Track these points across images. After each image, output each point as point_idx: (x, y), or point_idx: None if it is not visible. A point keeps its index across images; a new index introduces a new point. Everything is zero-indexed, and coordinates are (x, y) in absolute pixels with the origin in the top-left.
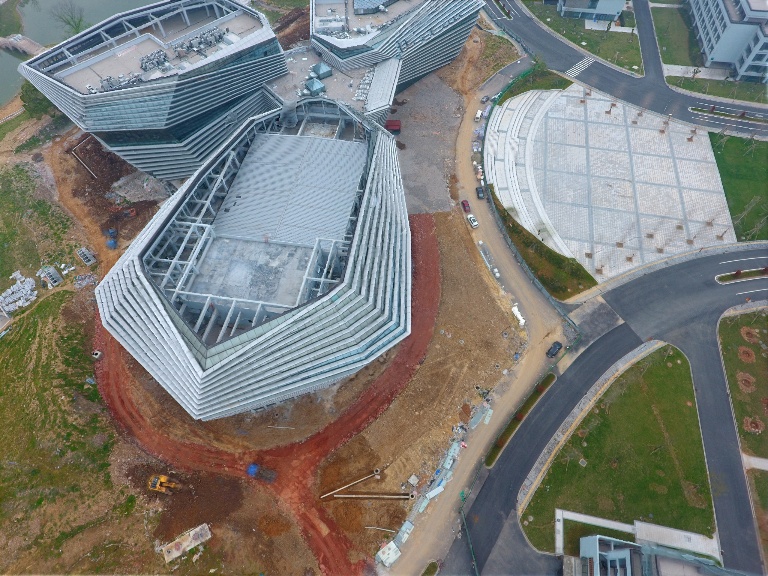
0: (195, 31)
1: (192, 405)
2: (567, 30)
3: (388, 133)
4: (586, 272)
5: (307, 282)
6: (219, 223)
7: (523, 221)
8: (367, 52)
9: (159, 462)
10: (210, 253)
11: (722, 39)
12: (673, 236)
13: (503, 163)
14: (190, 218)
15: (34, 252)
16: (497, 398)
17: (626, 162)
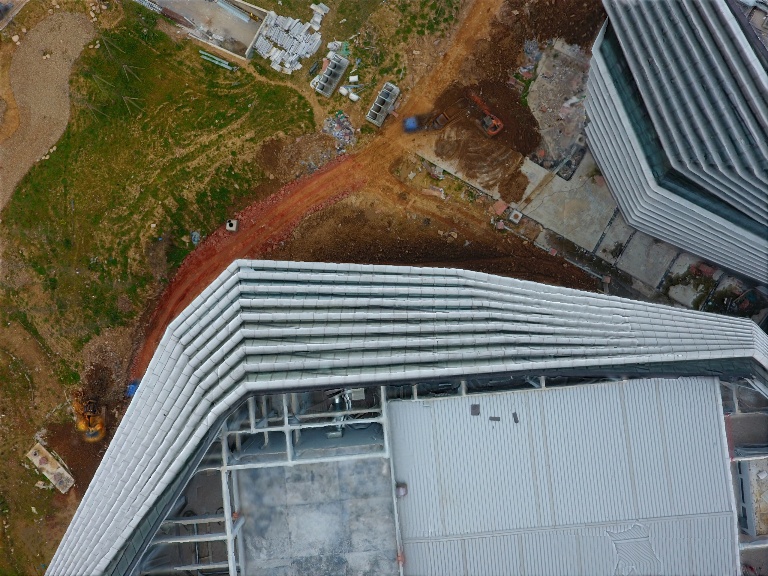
0: None
1: None
2: None
3: None
4: None
5: None
6: (439, 410)
7: None
8: None
9: (122, 391)
10: (349, 451)
11: None
12: None
13: None
14: None
15: (370, 7)
16: None
17: None
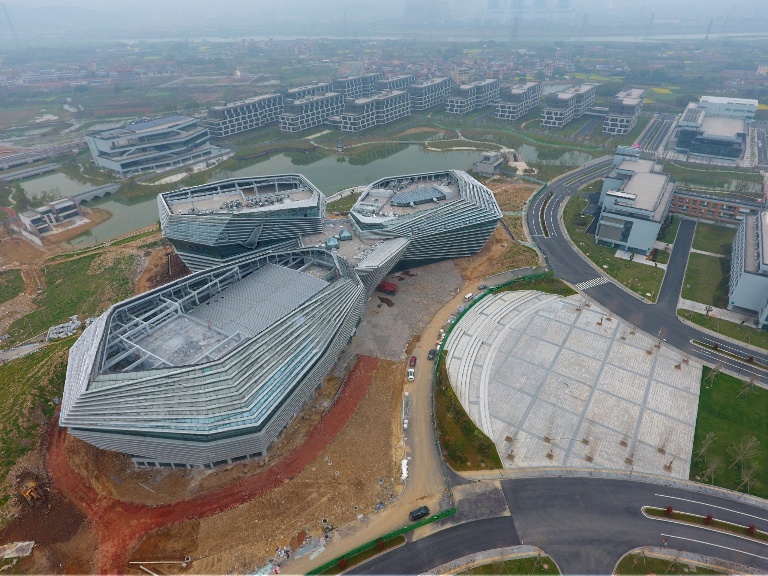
0: (269, 194)
1: (65, 414)
2: (595, 254)
3: (361, 283)
4: (496, 453)
5: (208, 359)
6: (196, 310)
7: (458, 389)
8: (382, 229)
9: (46, 477)
10: (169, 324)
11: (738, 285)
12: (612, 450)
13: (470, 338)
14: (175, 299)
15: (96, 307)
16: (337, 538)
17: (595, 369)
